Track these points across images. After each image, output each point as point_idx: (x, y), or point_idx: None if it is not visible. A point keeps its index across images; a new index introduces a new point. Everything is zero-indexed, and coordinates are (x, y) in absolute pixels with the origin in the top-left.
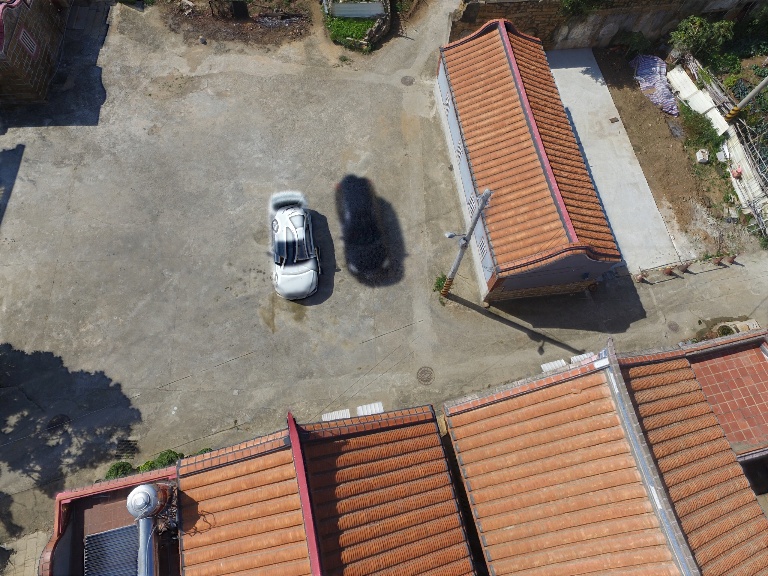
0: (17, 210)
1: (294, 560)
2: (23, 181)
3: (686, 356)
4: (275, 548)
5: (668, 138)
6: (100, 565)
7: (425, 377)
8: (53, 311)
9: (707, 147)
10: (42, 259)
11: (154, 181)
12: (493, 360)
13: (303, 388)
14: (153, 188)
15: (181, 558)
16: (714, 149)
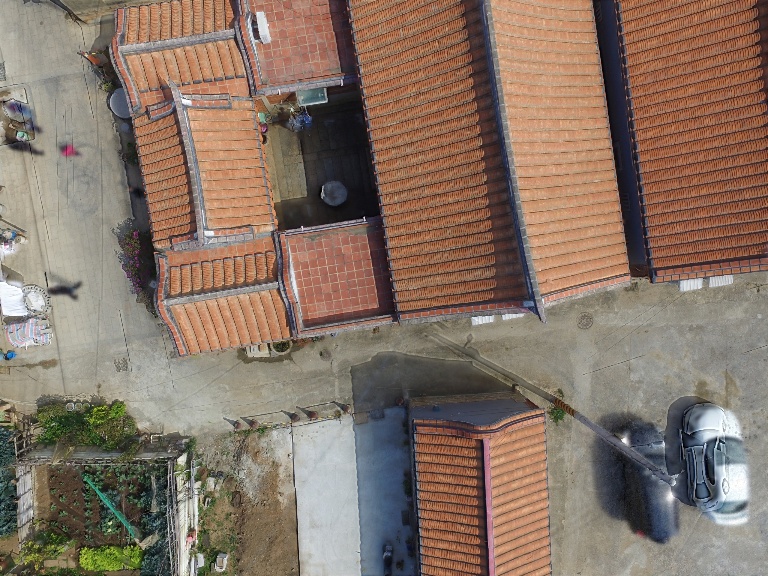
0: None
1: None
2: None
3: None
4: None
5: None
6: None
7: (586, 320)
8: None
9: (210, 575)
10: None
11: None
12: (519, 332)
13: (699, 317)
14: None
15: None
16: (204, 572)
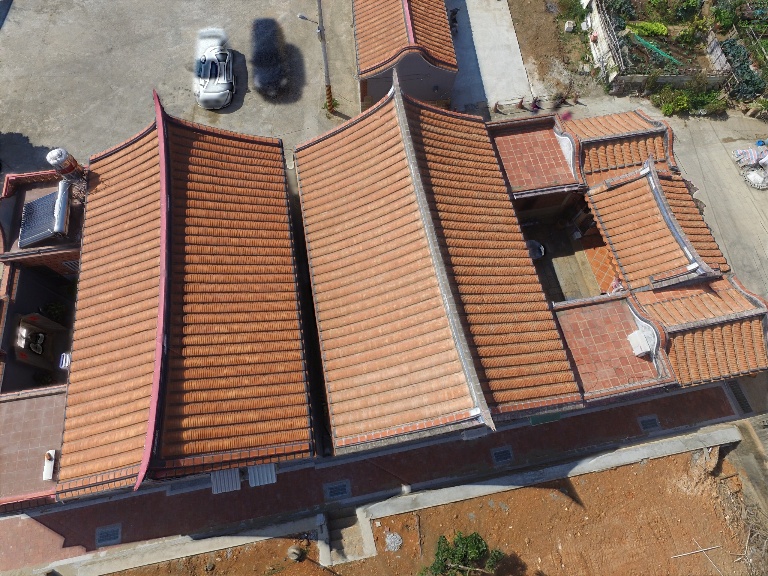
0: (4, 41)
1: (155, 193)
2: (10, 22)
3: (492, 131)
4: (144, 189)
5: (543, 13)
6: (32, 217)
7: None
8: (25, 107)
9: (575, 20)
10: (20, 73)
11: (112, 26)
12: None
13: None
14: (110, 30)
15: (85, 207)
16: (580, 21)
